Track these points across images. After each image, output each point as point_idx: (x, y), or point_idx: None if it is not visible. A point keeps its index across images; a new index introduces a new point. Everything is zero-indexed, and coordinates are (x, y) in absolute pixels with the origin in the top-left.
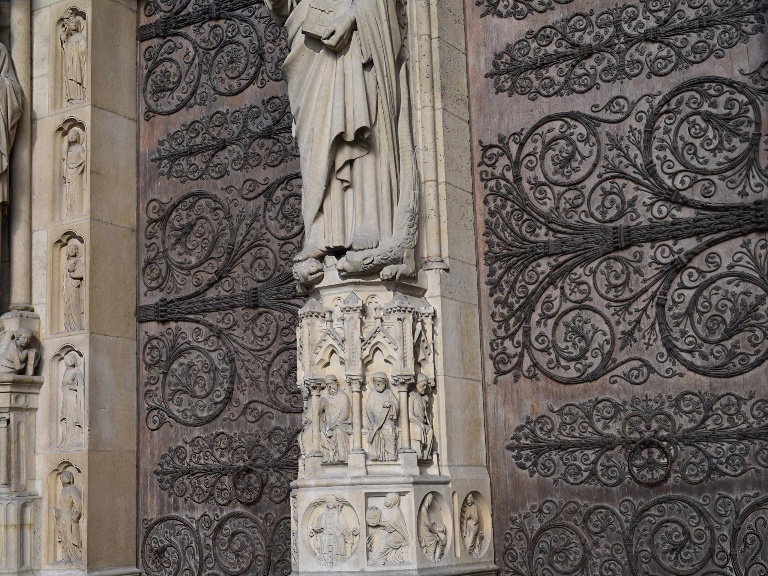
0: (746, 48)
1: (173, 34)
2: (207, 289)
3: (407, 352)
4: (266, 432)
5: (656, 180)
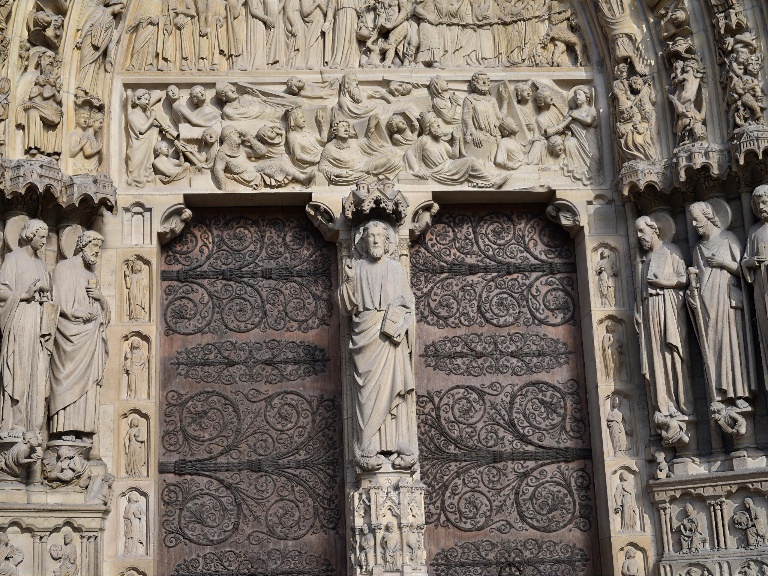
0: (561, 370)
1: (192, 282)
2: (219, 456)
3: (423, 511)
4: (266, 551)
5: (516, 429)
